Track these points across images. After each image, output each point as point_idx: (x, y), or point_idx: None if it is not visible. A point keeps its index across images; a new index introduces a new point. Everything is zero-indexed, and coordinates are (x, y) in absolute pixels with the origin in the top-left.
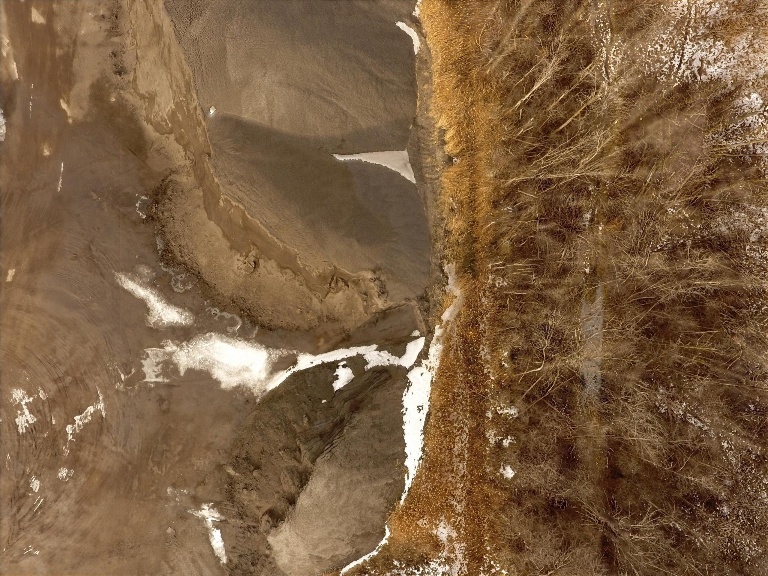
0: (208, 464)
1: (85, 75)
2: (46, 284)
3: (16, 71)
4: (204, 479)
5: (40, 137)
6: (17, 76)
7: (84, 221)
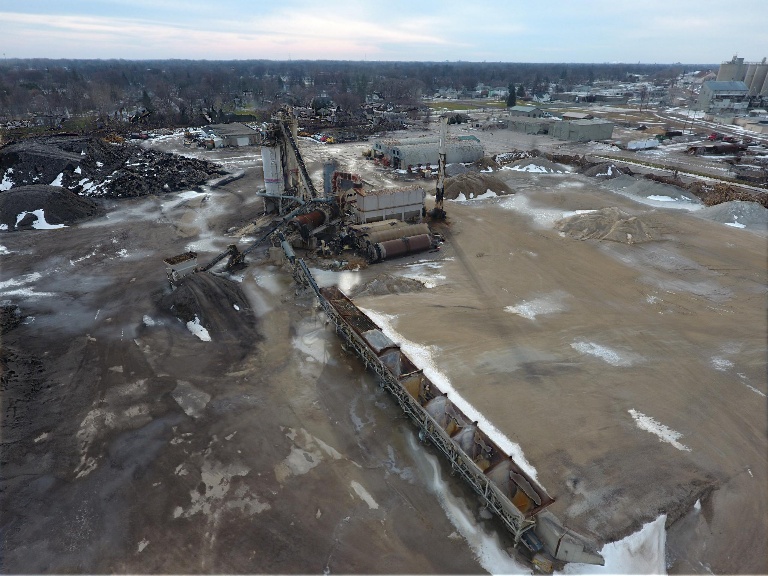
0: (1, 262)
1: (72, 355)
2: (108, 282)
3: (137, 342)
4: (6, 259)
5: (114, 323)
6: (135, 340)
7: (79, 305)
